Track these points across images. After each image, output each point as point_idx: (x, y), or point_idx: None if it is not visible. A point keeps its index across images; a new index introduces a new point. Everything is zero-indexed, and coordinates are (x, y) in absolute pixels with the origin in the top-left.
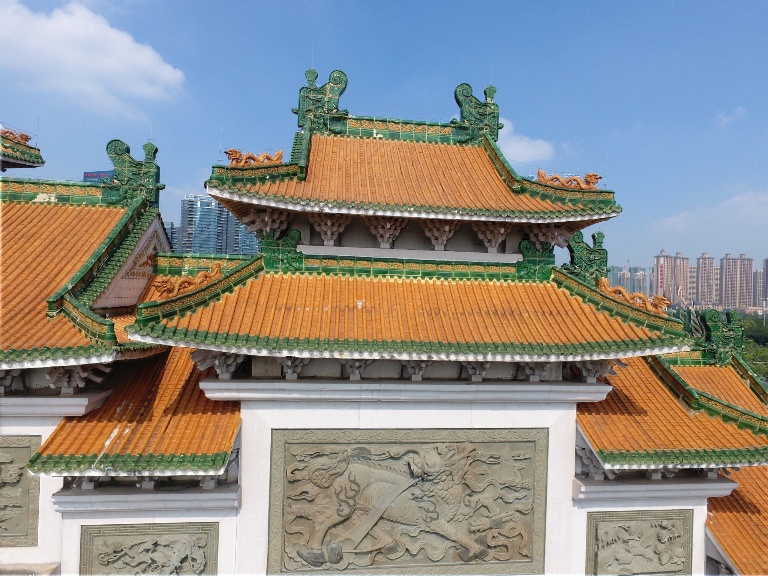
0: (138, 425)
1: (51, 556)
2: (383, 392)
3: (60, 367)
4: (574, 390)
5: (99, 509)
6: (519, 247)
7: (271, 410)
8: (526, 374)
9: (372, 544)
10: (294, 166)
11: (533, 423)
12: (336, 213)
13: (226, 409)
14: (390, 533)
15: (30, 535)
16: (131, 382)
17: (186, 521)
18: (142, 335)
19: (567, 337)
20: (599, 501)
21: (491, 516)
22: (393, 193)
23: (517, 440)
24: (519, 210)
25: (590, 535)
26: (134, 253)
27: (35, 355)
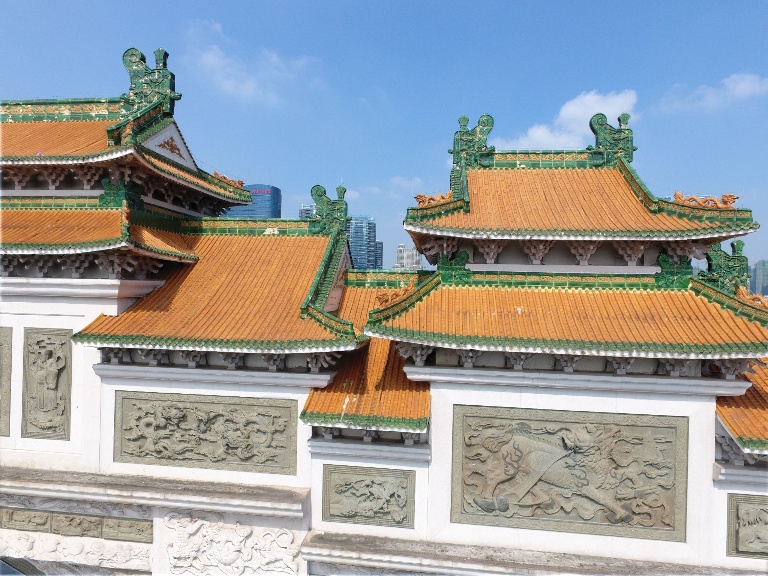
0: (361, 396)
1: (305, 483)
2: (541, 380)
3: (313, 353)
4: (713, 385)
5: (337, 453)
6: (657, 260)
7: (453, 390)
8: (666, 370)
9: (532, 500)
10: (460, 201)
11: (674, 412)
12: (499, 239)
13: (418, 388)
14: (547, 493)
15: (291, 467)
16: (348, 366)
17: (392, 468)
18: (373, 332)
19: (706, 339)
20: (740, 484)
21: (635, 487)
22: (543, 219)
23: (659, 425)
24: (658, 230)
25: (731, 514)
26: (337, 271)
27: (306, 344)
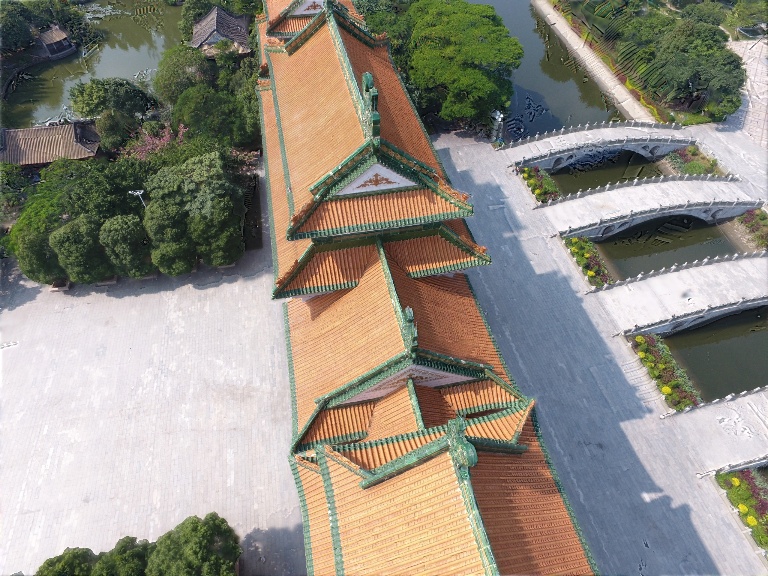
0: None
1: None
2: None
3: None
4: None
5: None
6: None
7: None
8: None
9: None
10: None
11: None
12: None
13: None
14: None
15: None
16: None
17: None
18: None
19: None
20: None
21: None
22: (364, 567)
23: None
24: None
25: None
26: (380, 383)
27: None
